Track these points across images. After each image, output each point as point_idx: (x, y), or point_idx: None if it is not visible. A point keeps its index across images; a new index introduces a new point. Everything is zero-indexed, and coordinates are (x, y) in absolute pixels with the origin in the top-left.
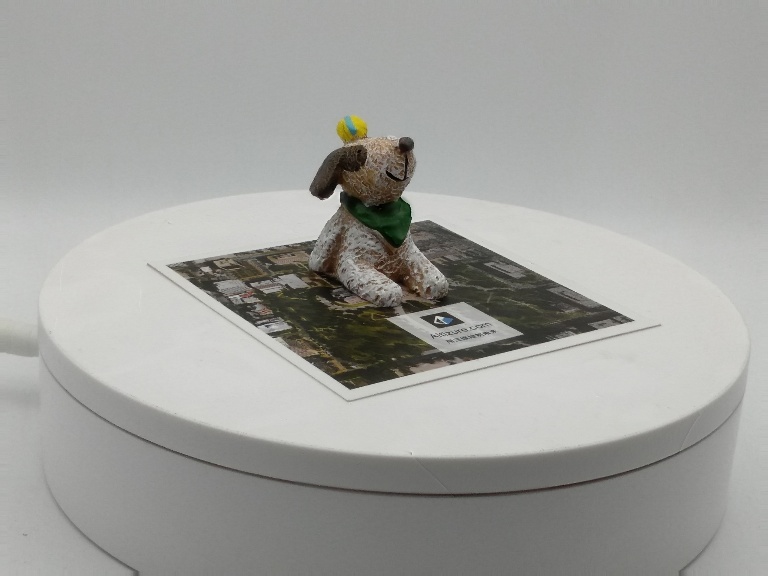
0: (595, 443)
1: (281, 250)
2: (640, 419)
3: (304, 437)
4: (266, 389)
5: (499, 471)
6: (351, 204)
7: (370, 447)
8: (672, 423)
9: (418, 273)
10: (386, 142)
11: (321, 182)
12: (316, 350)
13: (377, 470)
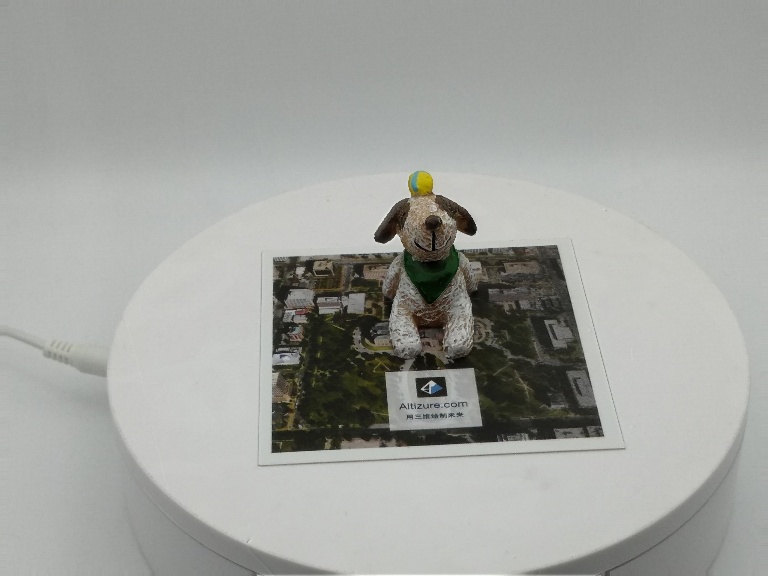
0: None
1: (384, 259)
2: (473, 564)
3: (189, 496)
4: (213, 432)
5: None
6: None
7: (226, 523)
8: None
9: (449, 328)
10: (423, 213)
11: (378, 229)
12: (291, 397)
13: (224, 544)
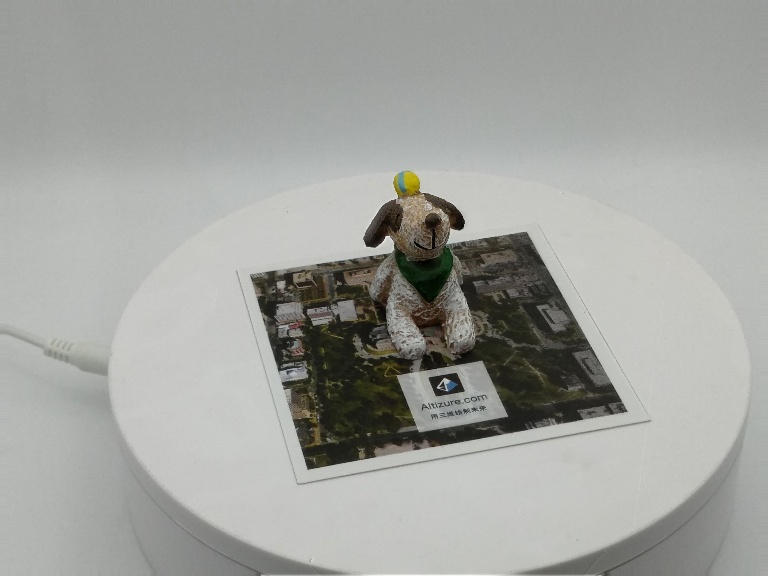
0: None
1: (362, 264)
2: (539, 552)
3: (236, 524)
4: (241, 456)
5: None
6: (399, 253)
7: (282, 546)
8: (567, 561)
9: (450, 325)
10: (420, 213)
11: (369, 234)
12: (310, 412)
13: (284, 567)
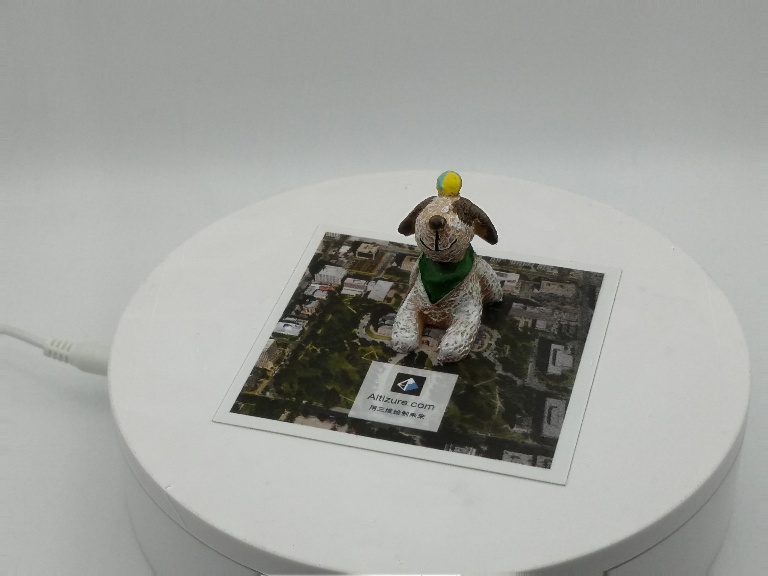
0: (288, 557)
1: None
2: (359, 559)
3: (138, 434)
4: (188, 381)
5: (214, 536)
6: None
7: (157, 466)
8: None
9: None
10: (434, 212)
11: None
12: (273, 365)
13: None
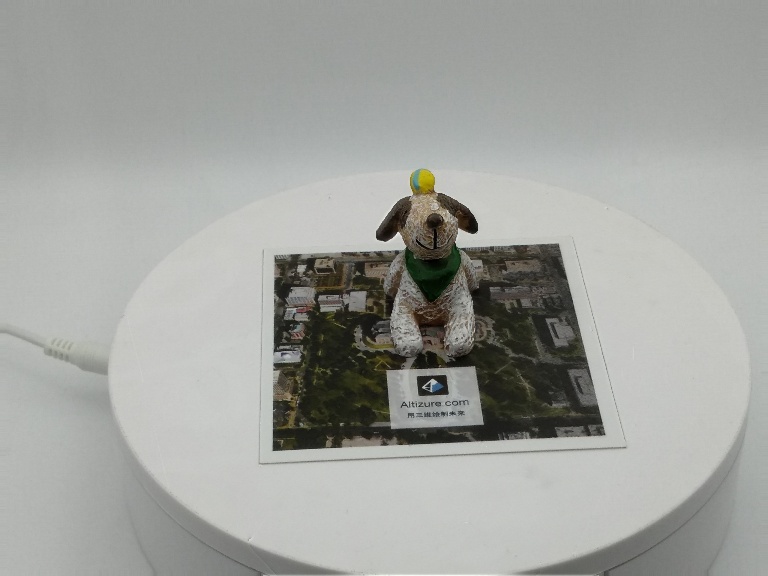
0: None
1: (386, 257)
2: (474, 562)
3: (190, 494)
4: (214, 430)
5: (315, 575)
6: None
7: (227, 521)
8: (500, 575)
9: (450, 327)
10: (425, 211)
11: (380, 227)
12: (292, 395)
13: (225, 542)
